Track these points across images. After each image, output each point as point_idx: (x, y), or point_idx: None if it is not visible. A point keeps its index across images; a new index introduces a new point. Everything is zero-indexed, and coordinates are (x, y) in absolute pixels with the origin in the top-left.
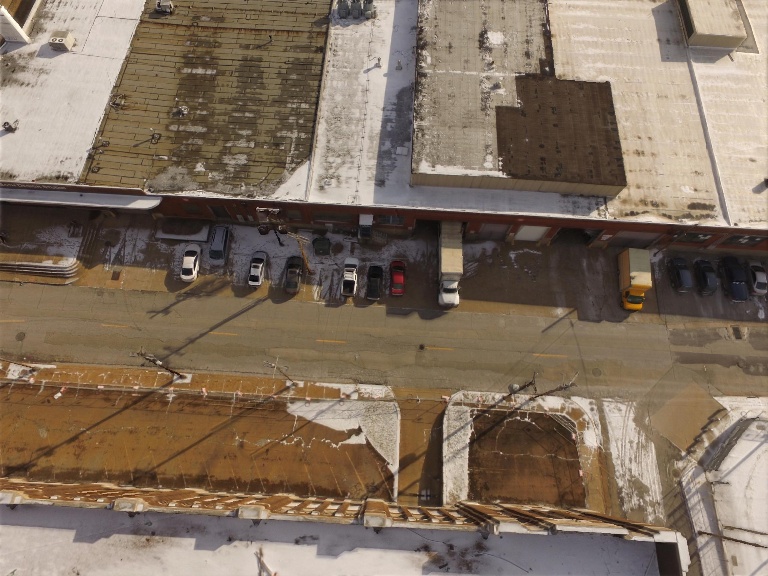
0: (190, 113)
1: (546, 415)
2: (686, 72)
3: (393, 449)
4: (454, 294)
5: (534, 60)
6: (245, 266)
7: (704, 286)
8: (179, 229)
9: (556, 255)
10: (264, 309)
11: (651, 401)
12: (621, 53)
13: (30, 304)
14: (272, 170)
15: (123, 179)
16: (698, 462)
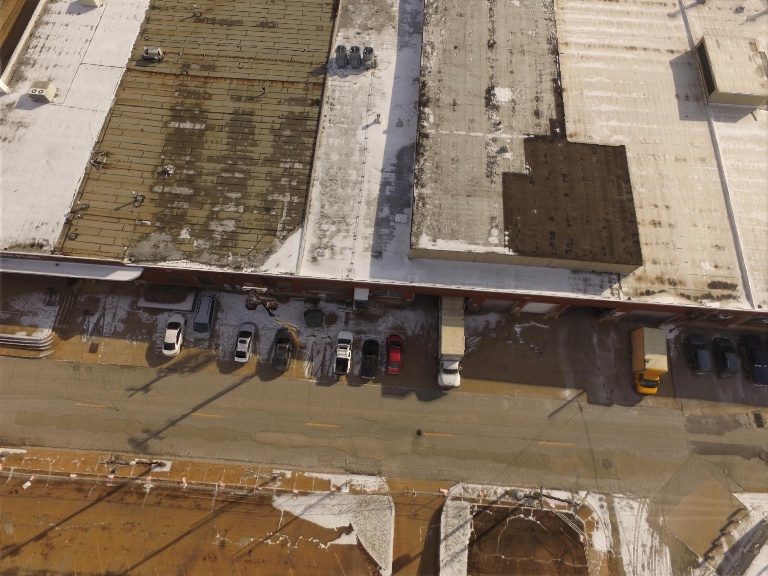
0: (176, 173)
1: (552, 513)
2: (706, 132)
3: (386, 551)
4: (455, 375)
5: (544, 120)
6: (232, 338)
7: (723, 368)
8: (162, 297)
9: (564, 329)
10: (251, 387)
11: (666, 498)
12: (637, 110)
13: (1, 380)
14: (262, 238)
15: (102, 247)
16: (716, 570)
